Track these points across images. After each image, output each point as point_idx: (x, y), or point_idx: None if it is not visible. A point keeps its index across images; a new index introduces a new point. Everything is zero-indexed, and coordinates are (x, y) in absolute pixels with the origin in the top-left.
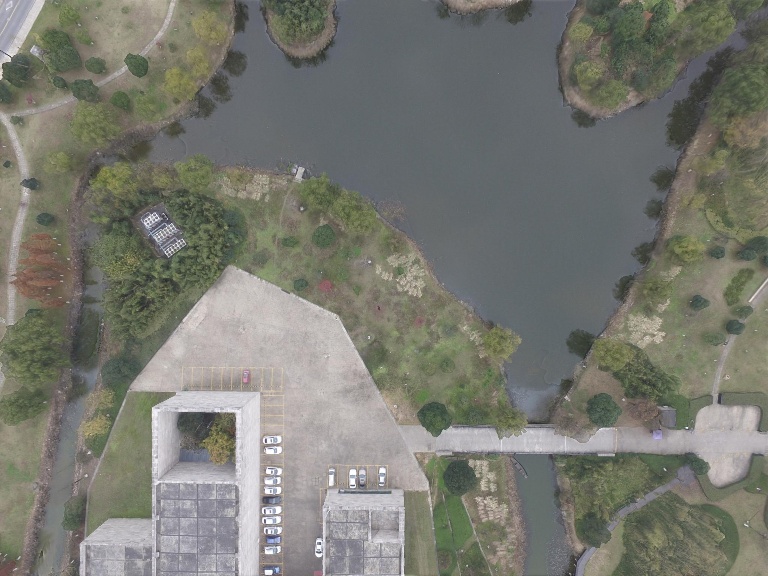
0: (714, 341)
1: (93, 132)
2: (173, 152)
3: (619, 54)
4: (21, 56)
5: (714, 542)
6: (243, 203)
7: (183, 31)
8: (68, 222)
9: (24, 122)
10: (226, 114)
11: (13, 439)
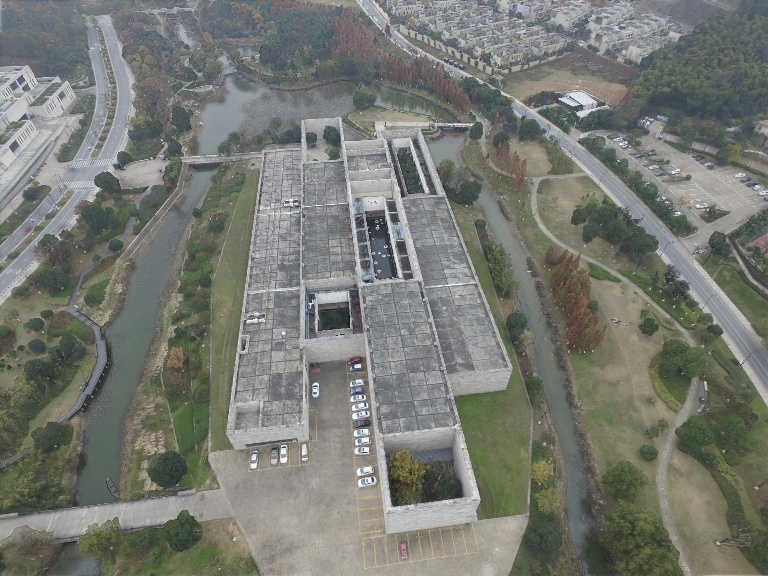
0: None
1: None
2: None
3: None
4: None
5: None
6: None
7: None
8: None
9: None
10: None
11: (622, 447)
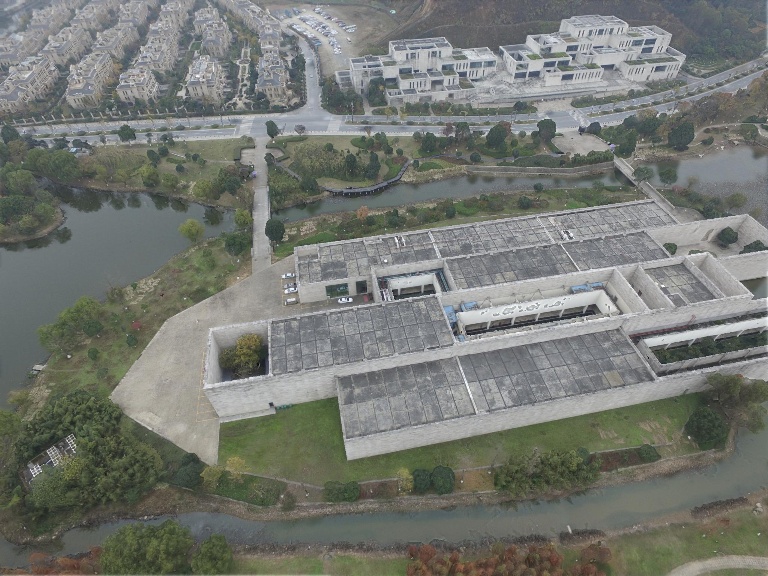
0: (200, 160)
1: None
2: None
3: (20, 209)
4: None
5: None
6: None
7: None
8: None
9: None
10: None
11: None
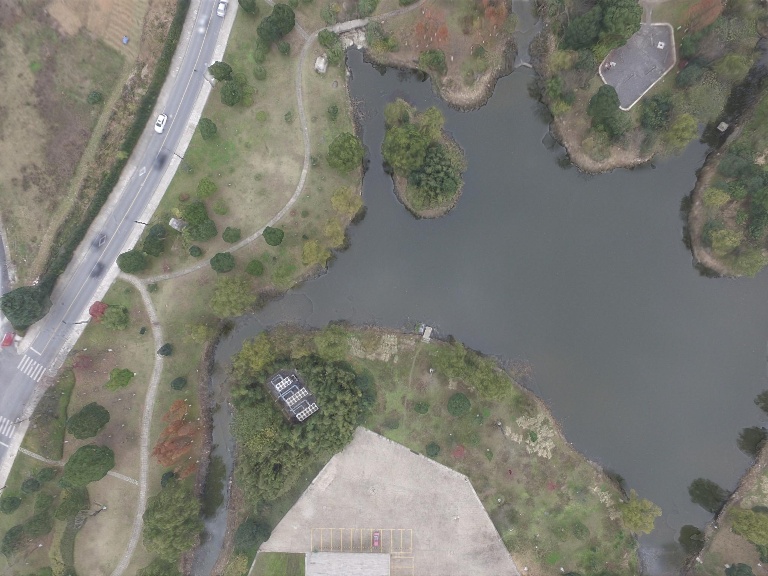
0: None
1: (234, 308)
2: (300, 311)
3: (758, 224)
4: (159, 228)
5: None
6: (372, 364)
7: (314, 197)
8: (198, 382)
9: (158, 287)
10: (344, 262)
11: None
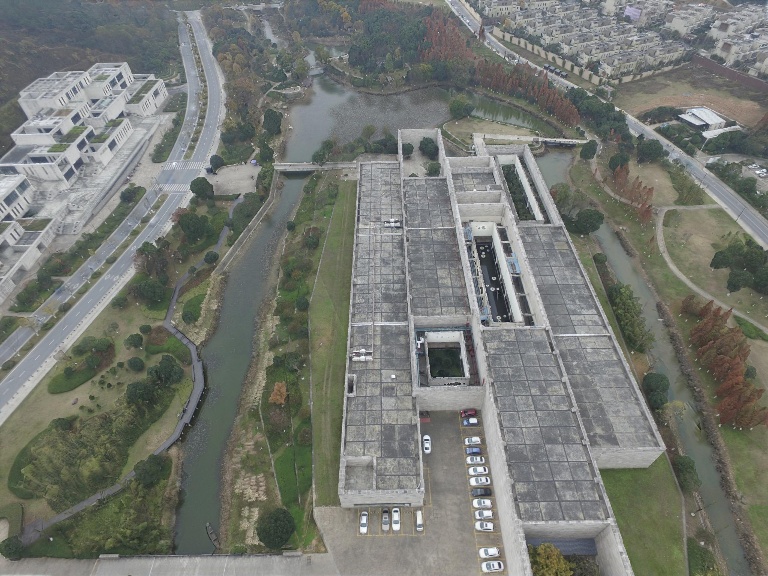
0: None
1: None
2: None
3: None
4: None
5: (36, 464)
6: None
7: None
8: None
9: None
10: None
11: None
